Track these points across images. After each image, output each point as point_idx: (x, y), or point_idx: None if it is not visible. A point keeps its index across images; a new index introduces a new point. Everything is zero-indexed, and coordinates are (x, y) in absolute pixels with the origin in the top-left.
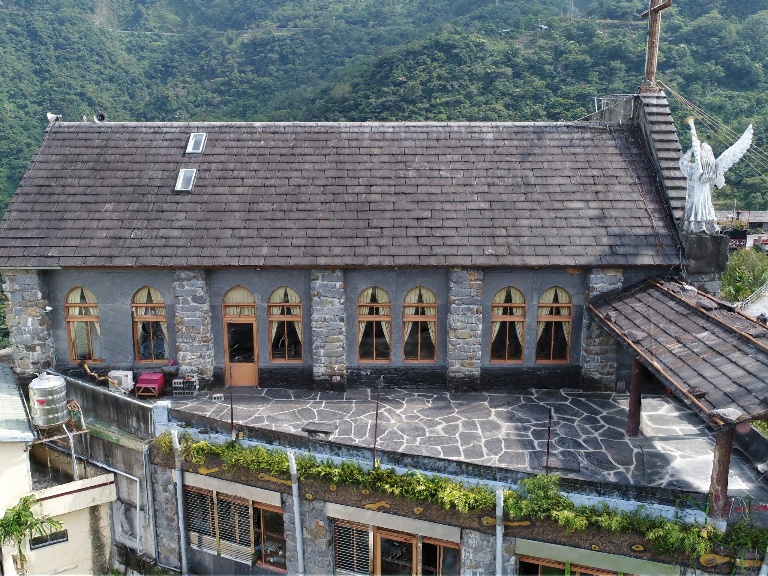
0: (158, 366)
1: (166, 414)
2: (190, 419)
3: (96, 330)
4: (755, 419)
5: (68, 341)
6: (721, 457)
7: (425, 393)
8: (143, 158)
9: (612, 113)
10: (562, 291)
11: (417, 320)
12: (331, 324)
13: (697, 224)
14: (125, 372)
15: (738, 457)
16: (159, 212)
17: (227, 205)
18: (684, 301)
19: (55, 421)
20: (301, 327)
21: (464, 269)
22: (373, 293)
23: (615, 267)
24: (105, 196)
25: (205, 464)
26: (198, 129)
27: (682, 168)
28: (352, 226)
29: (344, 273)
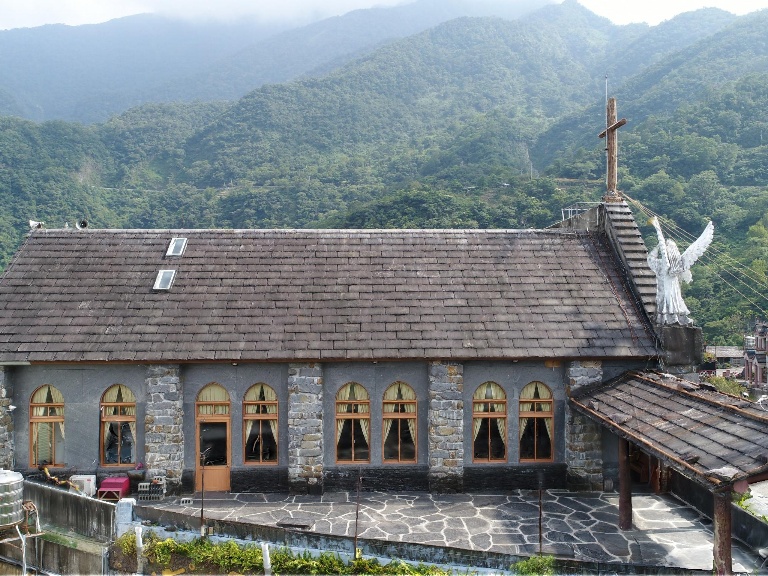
0: (124, 470)
1: (130, 512)
2: (156, 516)
3: (60, 432)
4: (751, 482)
5: (29, 444)
6: (721, 526)
7: (406, 495)
8: (123, 261)
9: (579, 221)
10: (542, 386)
11: (397, 417)
12: (308, 421)
13: (670, 316)
14: (88, 476)
15: (737, 546)
16: (136, 310)
17: (205, 303)
18: (665, 386)
19: (8, 521)
20: (277, 426)
21: (444, 363)
22: (351, 390)
23: (594, 359)
24: (81, 295)
25: (170, 565)
26: (179, 235)
27: (650, 264)
28: (331, 322)
29: (322, 368)
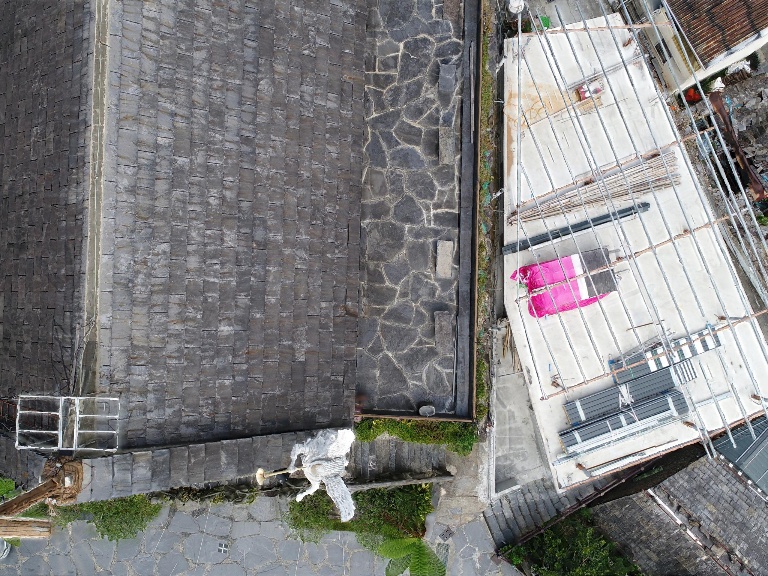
0: None
1: None
2: None
3: None
4: None
5: None
6: None
7: None
8: None
9: None
10: None
11: None
12: None
13: None
14: None
15: None
16: None
17: None
18: None
19: None
20: None
21: None
22: None
23: None
24: None
25: None
26: None
27: None
28: None
29: None
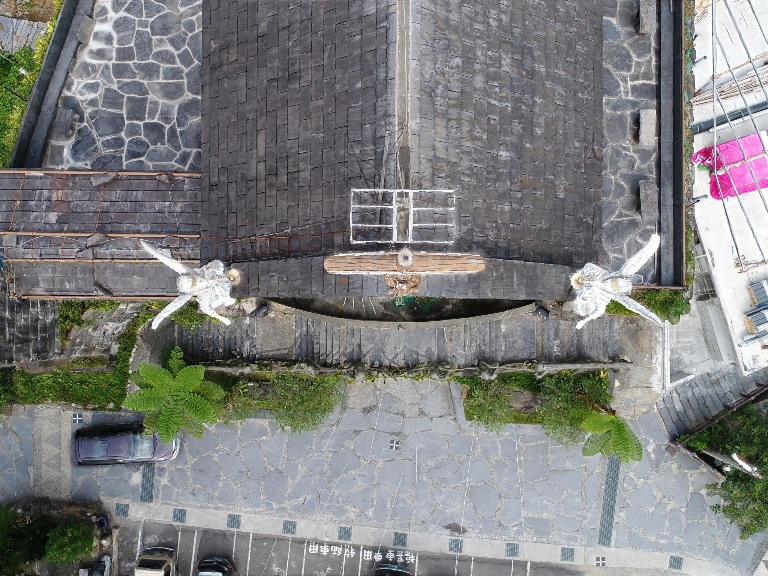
0: None
1: None
2: None
3: None
4: None
5: None
6: None
7: None
8: None
9: None
10: None
11: None
12: None
13: None
14: None
15: None
16: None
17: None
18: None
19: None
20: None
21: None
22: None
23: None
24: None
25: None
26: None
27: None
28: None
29: None
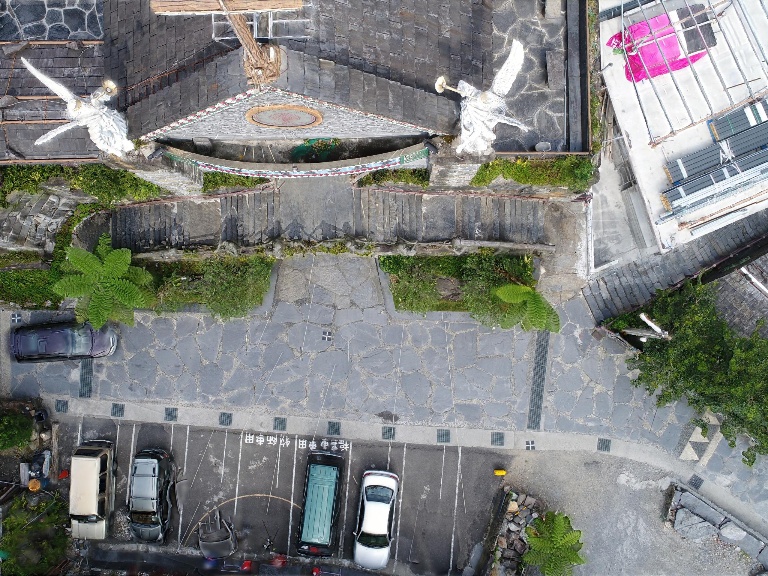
0: None
1: None
2: None
3: None
4: None
5: None
6: None
7: None
8: None
9: None
10: None
11: None
12: None
13: None
14: None
15: None
16: None
17: None
18: None
19: None
20: None
21: None
22: None
23: None
24: None
25: None
26: None
27: None
28: None
29: None
